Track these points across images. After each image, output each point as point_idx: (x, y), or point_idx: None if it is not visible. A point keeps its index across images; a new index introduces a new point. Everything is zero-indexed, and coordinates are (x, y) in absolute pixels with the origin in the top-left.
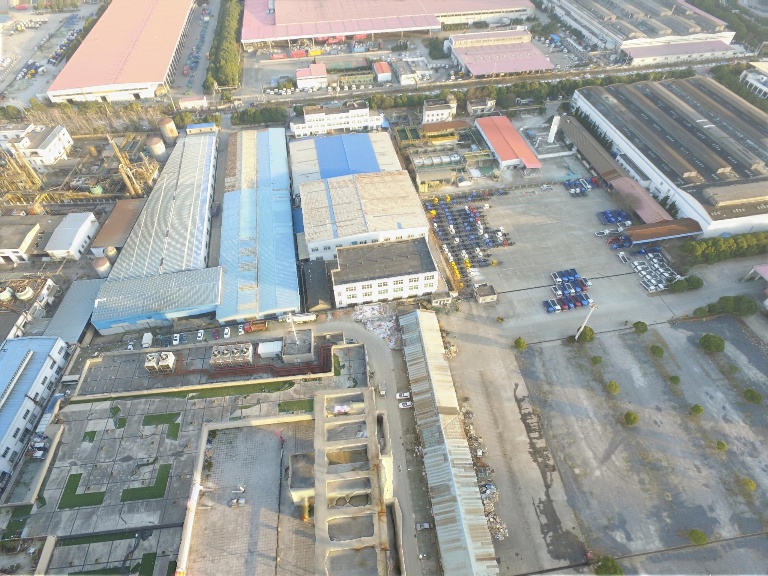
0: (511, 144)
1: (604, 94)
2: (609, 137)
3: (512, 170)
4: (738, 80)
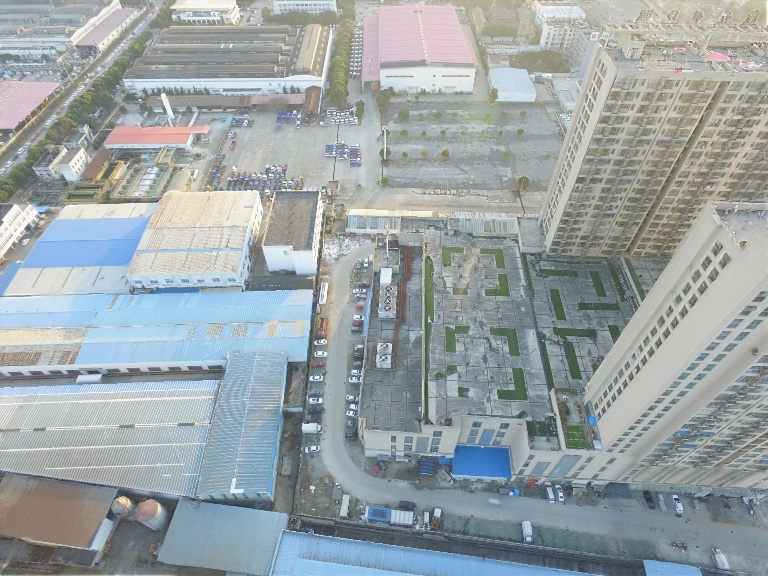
0: (168, 132)
1: (150, 67)
2: (198, 88)
3: (195, 146)
4: (179, 22)
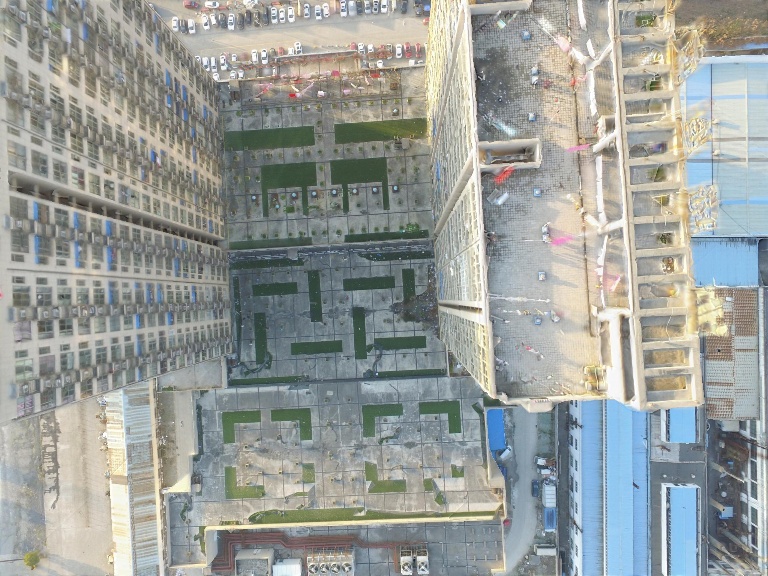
0: None
1: None
2: None
3: None
4: None
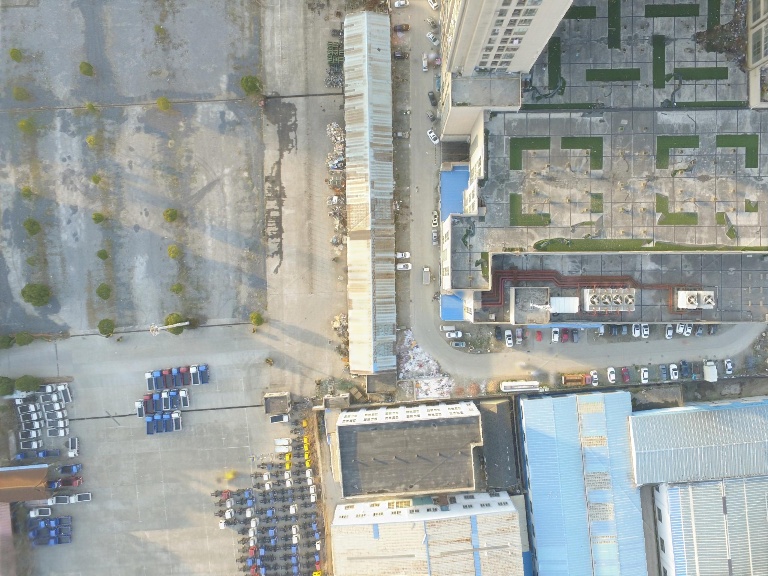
0: None
1: None
2: None
3: None
4: None
